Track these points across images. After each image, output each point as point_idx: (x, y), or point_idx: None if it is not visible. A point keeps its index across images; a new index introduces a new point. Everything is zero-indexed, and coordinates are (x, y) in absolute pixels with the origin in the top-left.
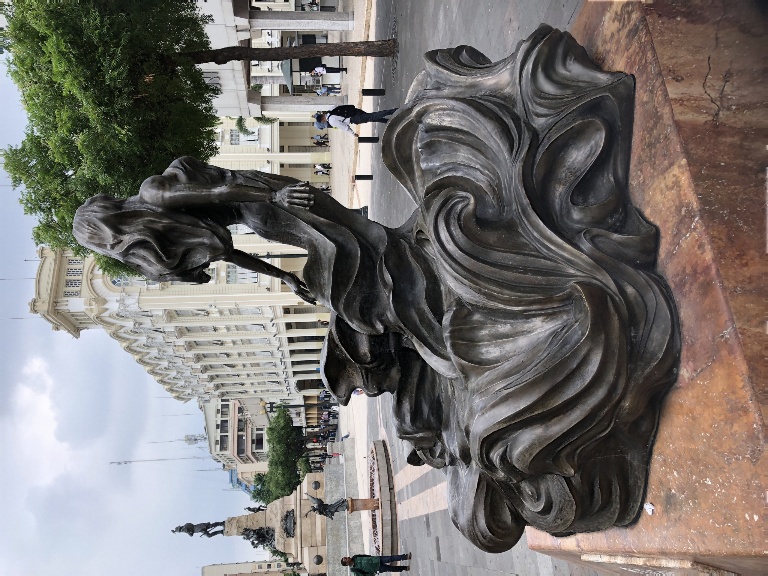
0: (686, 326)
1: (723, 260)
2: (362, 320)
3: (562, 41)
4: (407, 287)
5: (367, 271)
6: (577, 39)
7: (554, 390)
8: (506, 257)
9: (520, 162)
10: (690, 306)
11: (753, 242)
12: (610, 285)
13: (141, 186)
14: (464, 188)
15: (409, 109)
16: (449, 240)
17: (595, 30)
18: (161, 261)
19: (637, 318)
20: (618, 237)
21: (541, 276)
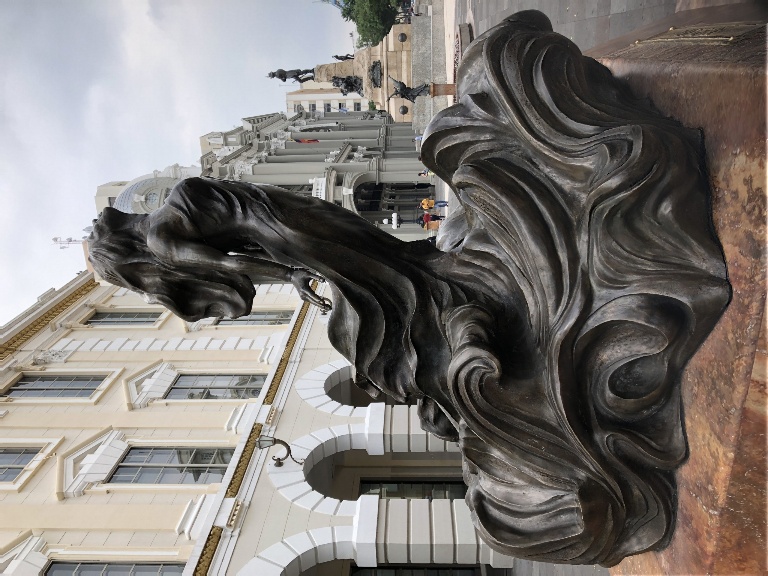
0: (676, 545)
1: (722, 558)
2: (386, 384)
3: (662, 182)
4: (434, 350)
5: (393, 337)
6: (706, 102)
7: (539, 554)
8: (524, 425)
9: (561, 335)
10: (684, 543)
11: (761, 555)
12: (617, 491)
13: (147, 241)
14: (490, 355)
15: (456, 128)
16: (467, 398)
17: (725, 142)
18: (186, 316)
19: (636, 513)
20: (642, 451)
21: (554, 455)
